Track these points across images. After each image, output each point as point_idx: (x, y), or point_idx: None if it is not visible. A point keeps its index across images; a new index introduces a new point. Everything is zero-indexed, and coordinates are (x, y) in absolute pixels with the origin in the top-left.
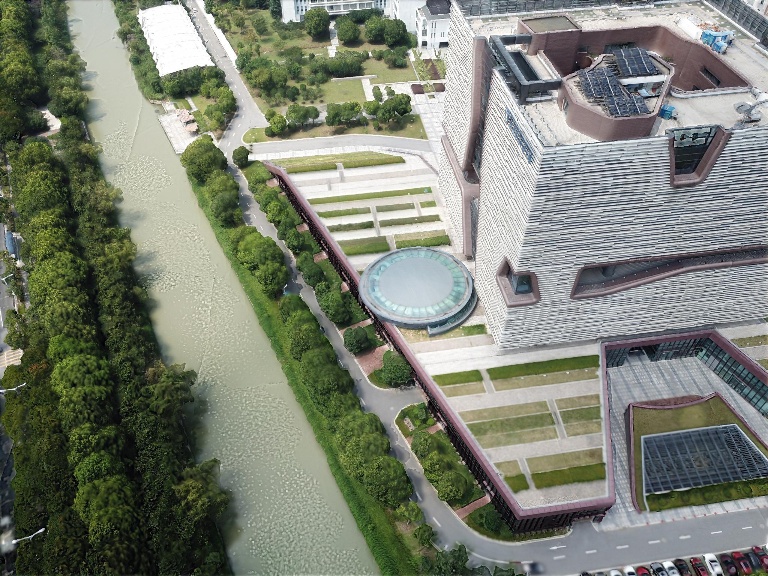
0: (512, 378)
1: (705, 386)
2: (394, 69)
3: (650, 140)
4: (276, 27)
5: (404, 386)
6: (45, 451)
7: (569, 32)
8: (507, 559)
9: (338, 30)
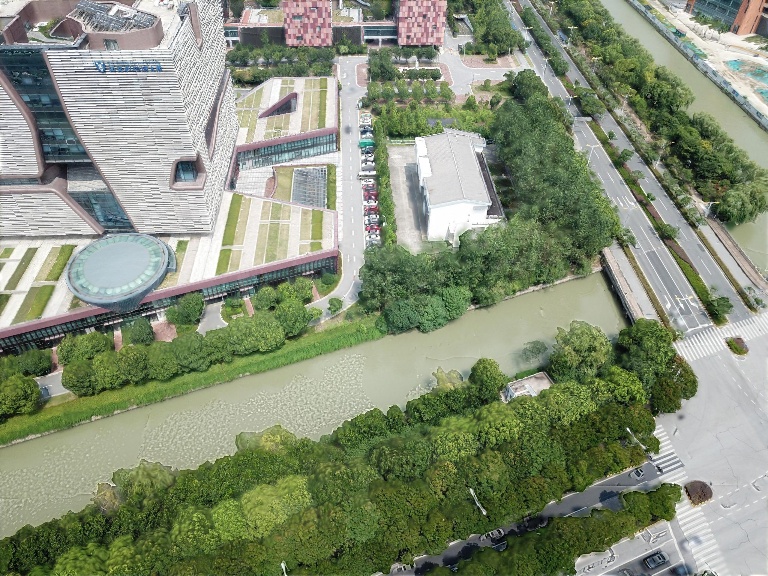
0: (235, 235)
1: (262, 175)
2: None
3: (186, 21)
4: None
5: (200, 316)
6: (193, 575)
7: (16, 21)
8: (351, 281)
9: None
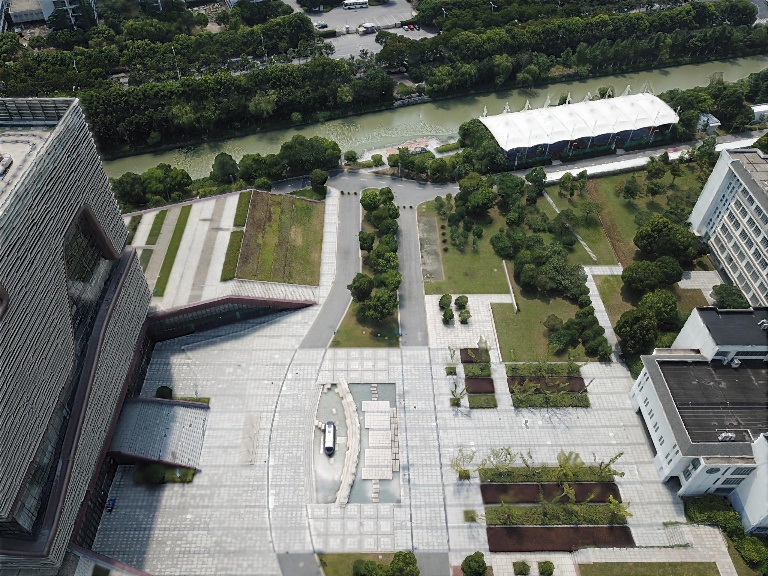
0: None
1: None
2: (546, 336)
3: None
4: (667, 211)
5: None
6: None
7: None
8: None
9: (637, 261)
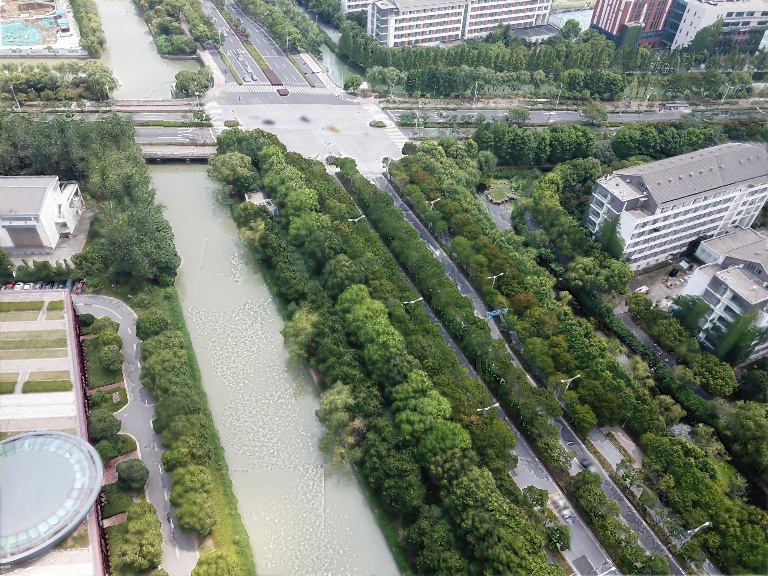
0: None
1: None
2: None
3: None
4: None
5: None
6: None
7: None
8: (92, 307)
9: None
